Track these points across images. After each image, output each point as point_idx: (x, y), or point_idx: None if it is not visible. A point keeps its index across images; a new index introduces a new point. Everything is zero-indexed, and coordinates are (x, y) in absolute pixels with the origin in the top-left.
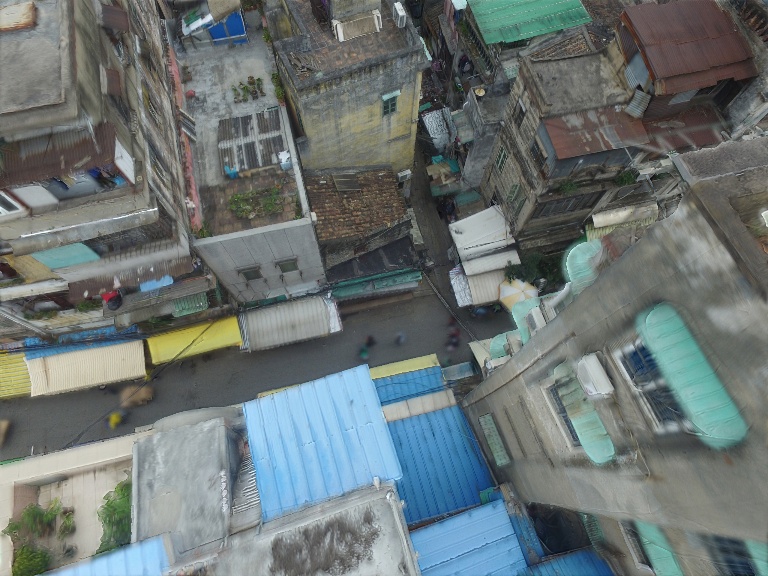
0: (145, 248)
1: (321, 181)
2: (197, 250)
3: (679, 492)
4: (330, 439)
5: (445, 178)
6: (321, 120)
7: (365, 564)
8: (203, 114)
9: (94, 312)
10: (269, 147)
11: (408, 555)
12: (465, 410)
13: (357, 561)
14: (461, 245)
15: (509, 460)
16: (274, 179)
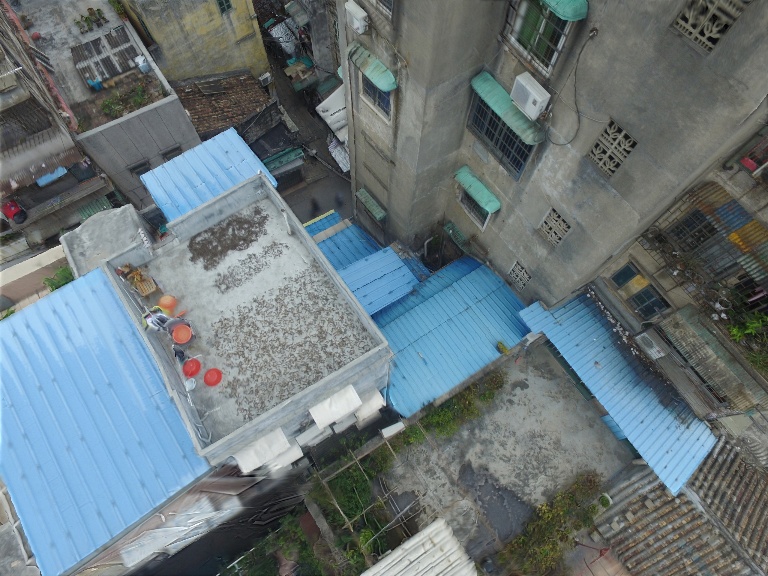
0: (29, 140)
1: (187, 90)
2: (82, 146)
3: (423, 62)
4: (216, 178)
5: (302, 74)
6: (164, 23)
7: (262, 238)
8: (54, 49)
9: (5, 248)
10: (124, 56)
11: (283, 203)
12: (358, 220)
13: (256, 238)
14: (330, 120)
15: (385, 213)
16: (137, 83)
